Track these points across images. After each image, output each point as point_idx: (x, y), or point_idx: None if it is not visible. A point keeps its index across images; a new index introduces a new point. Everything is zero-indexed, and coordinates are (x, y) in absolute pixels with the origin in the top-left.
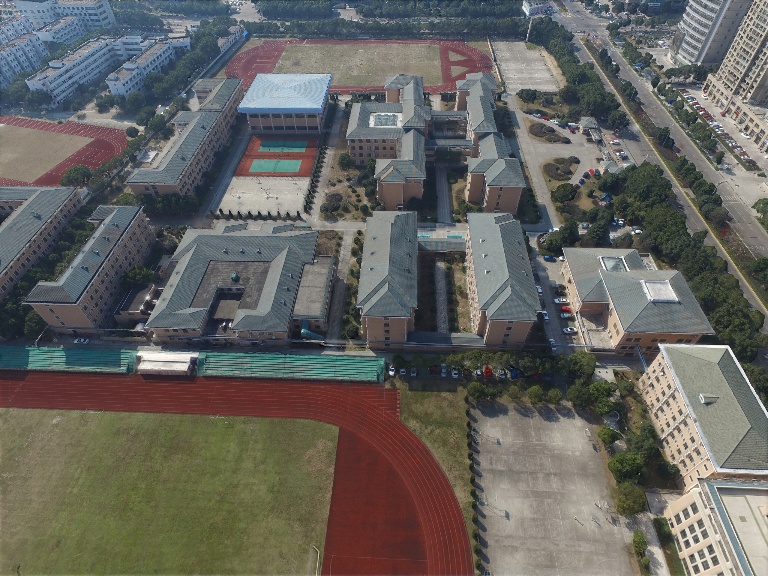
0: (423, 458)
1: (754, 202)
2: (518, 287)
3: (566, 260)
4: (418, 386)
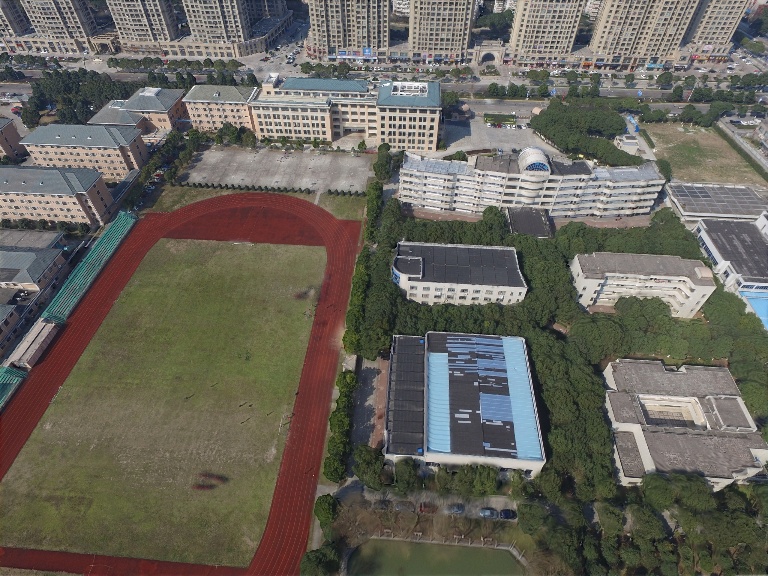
0: (200, 204)
1: (104, 69)
2: (113, 127)
3: (99, 123)
4: (151, 204)
